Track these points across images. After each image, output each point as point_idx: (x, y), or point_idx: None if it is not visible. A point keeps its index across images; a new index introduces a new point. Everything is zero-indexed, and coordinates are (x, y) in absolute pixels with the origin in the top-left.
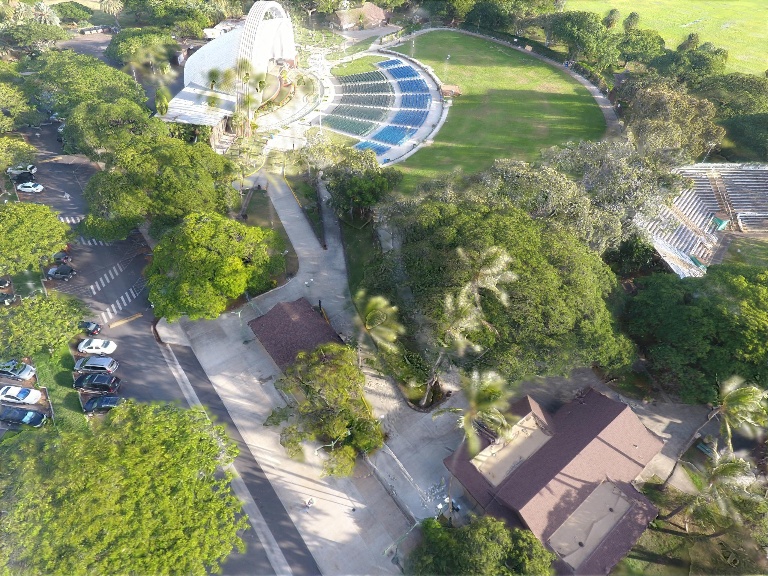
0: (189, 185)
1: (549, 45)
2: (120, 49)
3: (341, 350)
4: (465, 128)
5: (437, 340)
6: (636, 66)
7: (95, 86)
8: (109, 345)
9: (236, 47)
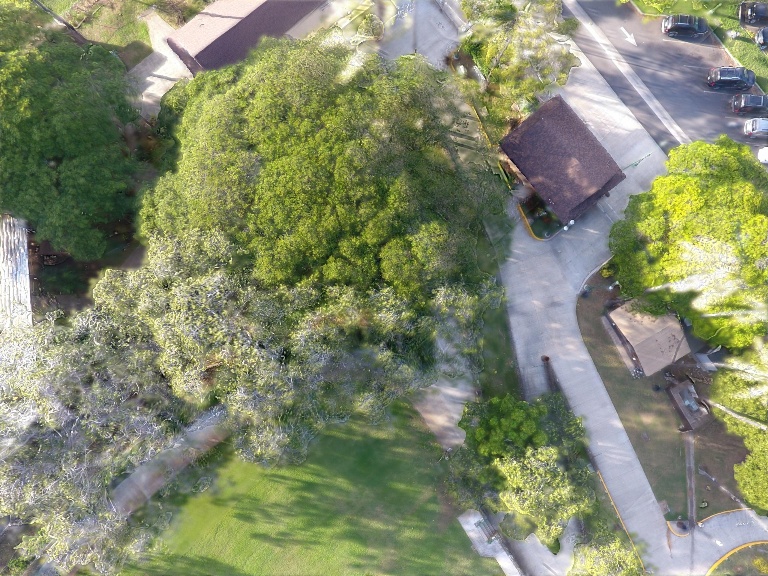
0: None
1: None
2: None
3: (519, 88)
4: None
5: (417, 57)
6: None
7: None
8: None
9: None
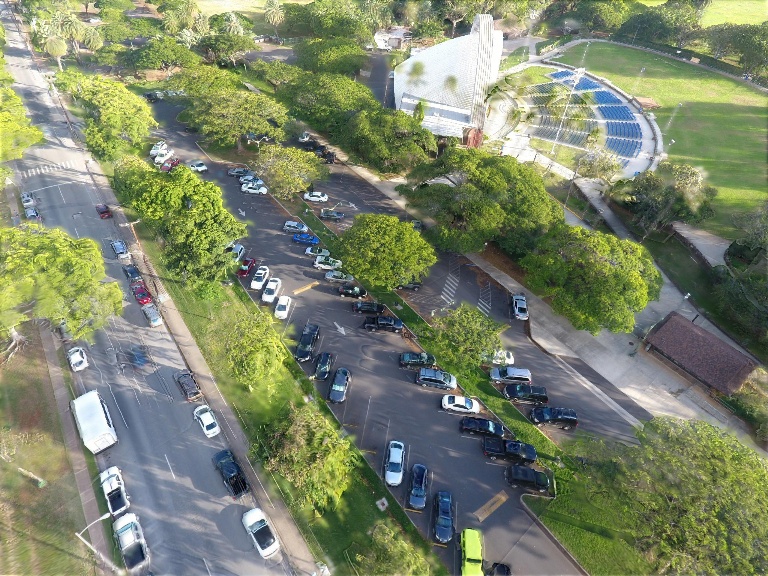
0: (538, 198)
1: (719, 57)
2: (320, 60)
3: None
4: (689, 141)
5: None
6: None
7: (351, 97)
8: (511, 356)
9: (461, 59)
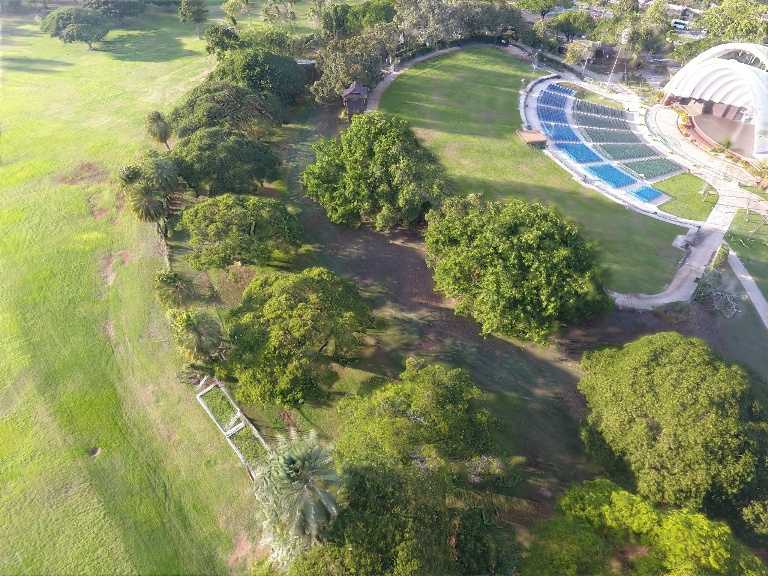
0: None
1: None
2: None
3: None
4: (500, 101)
5: None
6: (361, 66)
7: None
8: None
9: None
